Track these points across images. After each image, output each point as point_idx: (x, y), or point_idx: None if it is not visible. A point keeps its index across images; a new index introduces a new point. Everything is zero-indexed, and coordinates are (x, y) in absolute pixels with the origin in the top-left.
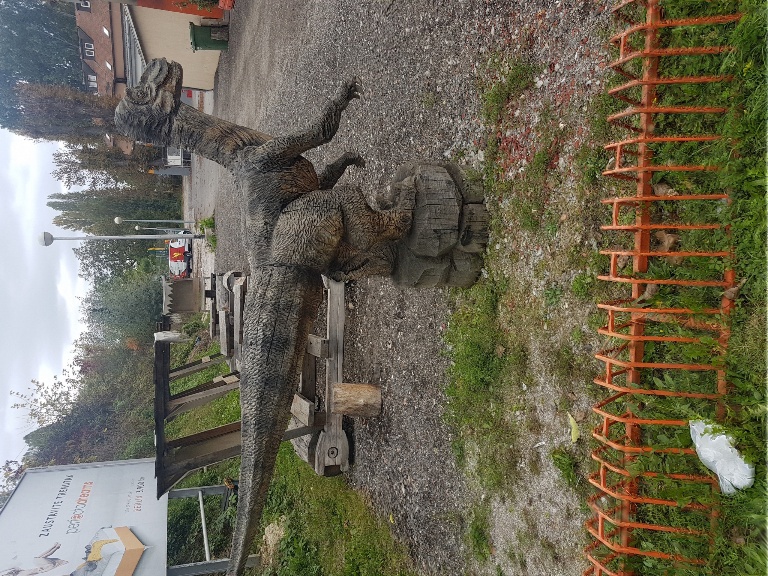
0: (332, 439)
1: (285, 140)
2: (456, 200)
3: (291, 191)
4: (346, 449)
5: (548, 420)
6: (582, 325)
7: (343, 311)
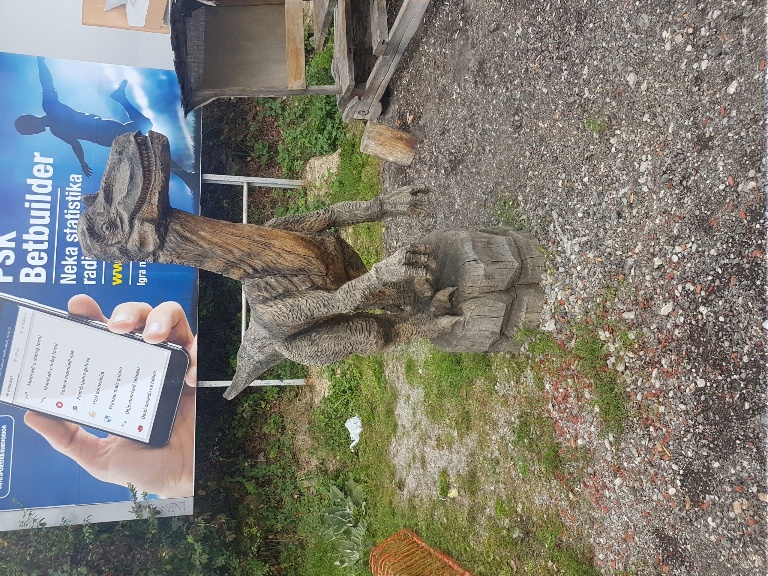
0: (366, 105)
1: (302, 319)
2: (490, 344)
3: (302, 328)
4: (378, 111)
5: (454, 459)
6: (488, 507)
7: (418, 23)
